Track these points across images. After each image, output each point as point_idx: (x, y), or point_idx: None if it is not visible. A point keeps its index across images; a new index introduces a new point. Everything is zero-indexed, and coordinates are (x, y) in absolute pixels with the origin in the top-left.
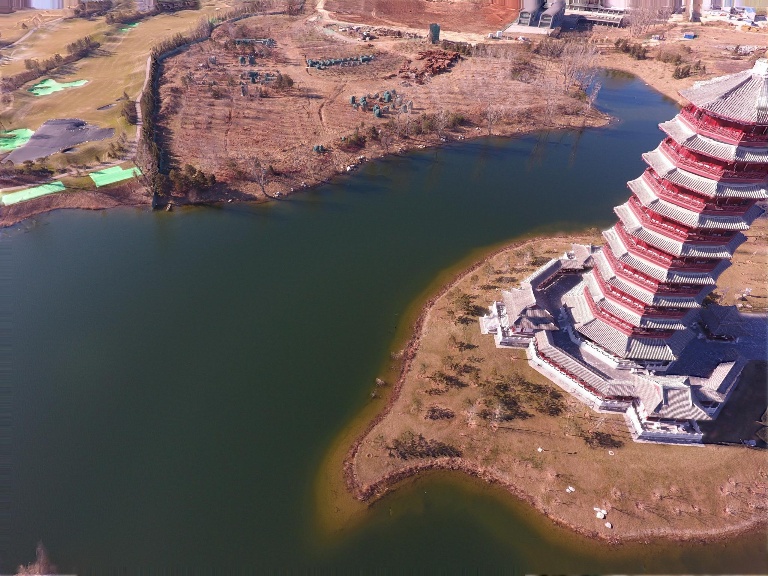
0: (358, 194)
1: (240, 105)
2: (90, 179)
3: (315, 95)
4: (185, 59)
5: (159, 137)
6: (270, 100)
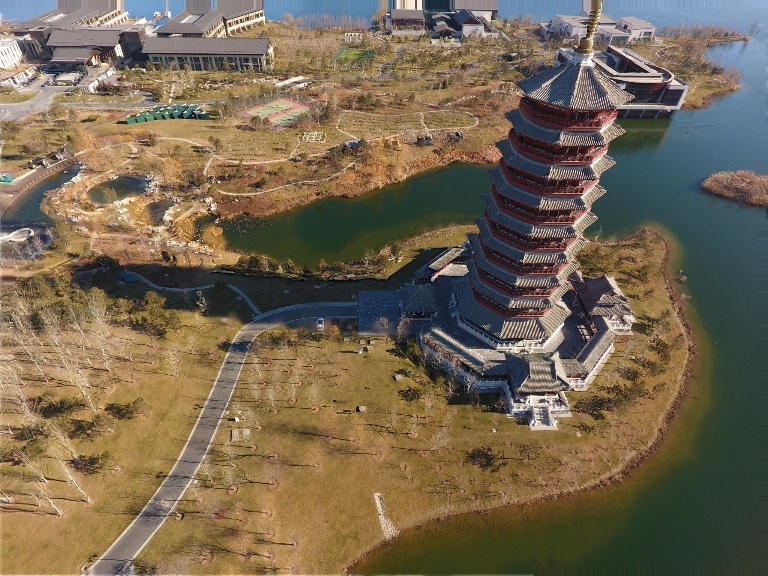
0: None
1: None
2: None
3: None
4: None
5: None
6: None
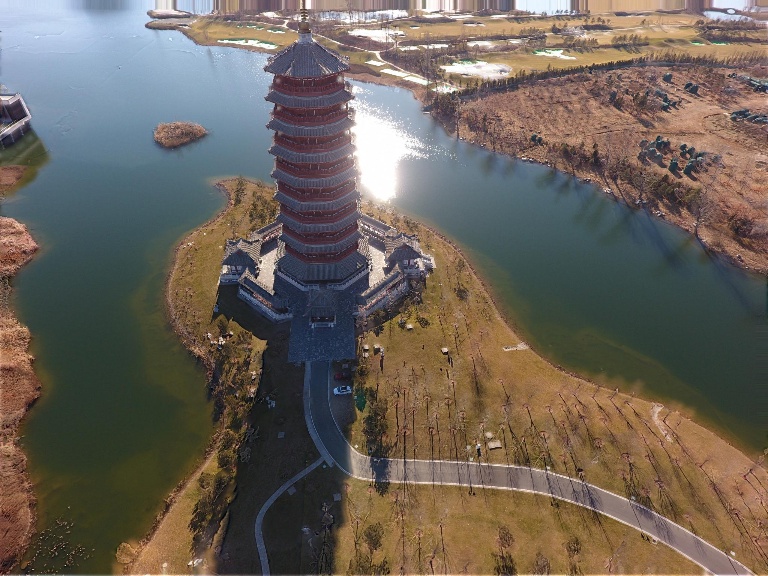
0: (486, 167)
1: None
2: None
3: (650, 124)
4: (658, 70)
5: (502, 89)
6: (612, 109)
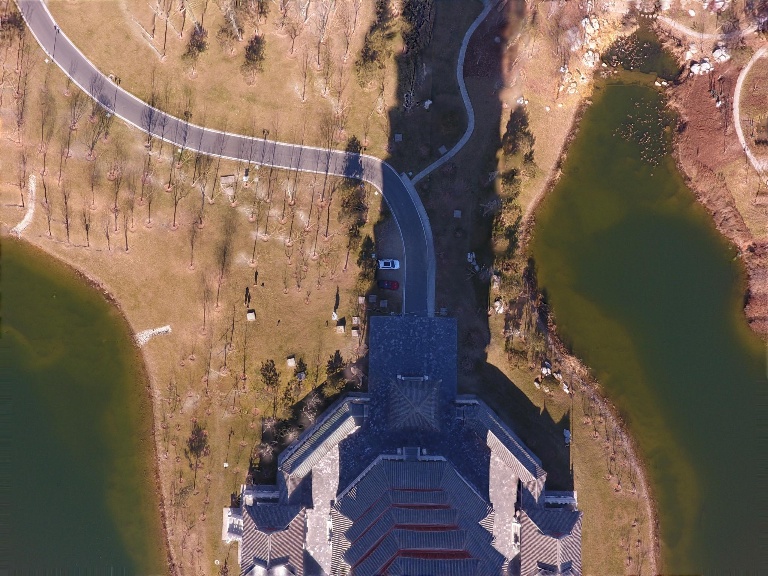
0: None
1: None
2: None
3: None
4: None
5: None
6: None
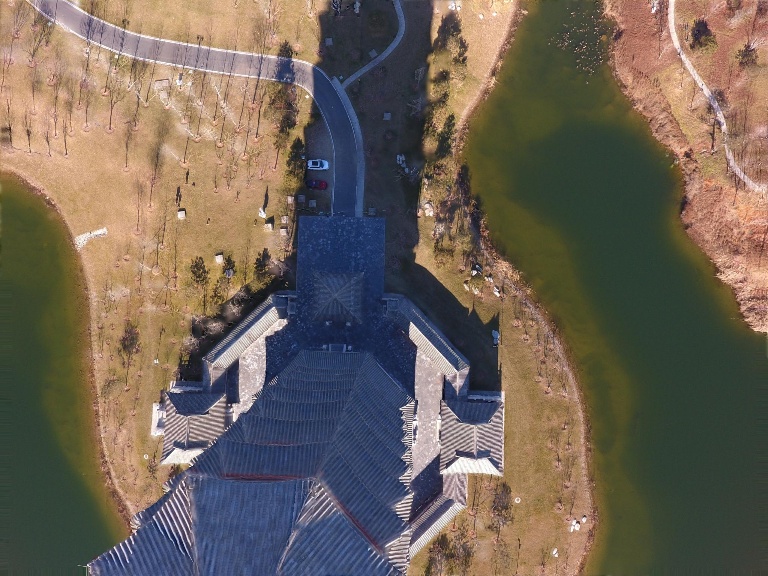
0: None
1: None
2: None
3: None
4: None
5: None
6: None
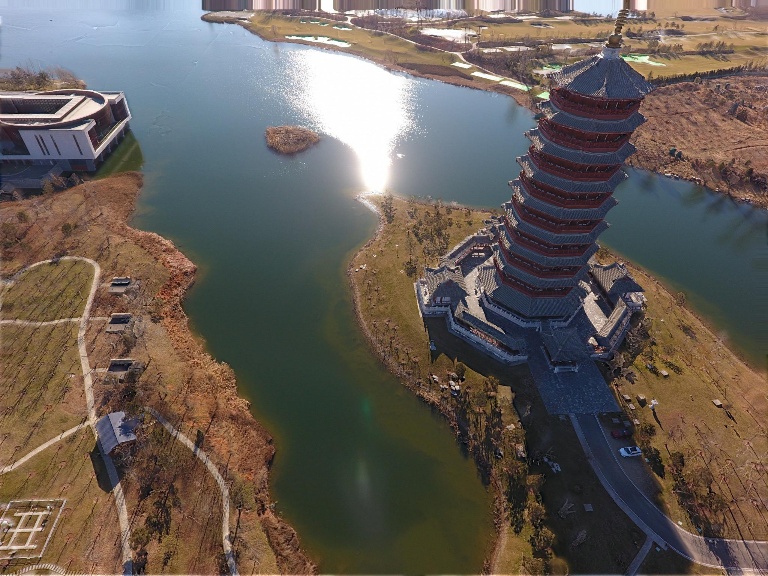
0: (632, 183)
1: (707, 113)
2: (541, 93)
3: None
4: (761, 80)
5: None
6: (737, 122)
